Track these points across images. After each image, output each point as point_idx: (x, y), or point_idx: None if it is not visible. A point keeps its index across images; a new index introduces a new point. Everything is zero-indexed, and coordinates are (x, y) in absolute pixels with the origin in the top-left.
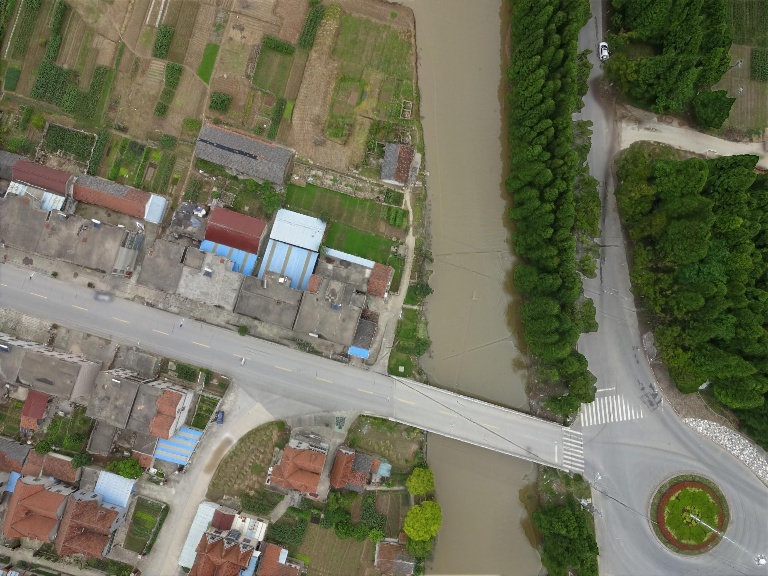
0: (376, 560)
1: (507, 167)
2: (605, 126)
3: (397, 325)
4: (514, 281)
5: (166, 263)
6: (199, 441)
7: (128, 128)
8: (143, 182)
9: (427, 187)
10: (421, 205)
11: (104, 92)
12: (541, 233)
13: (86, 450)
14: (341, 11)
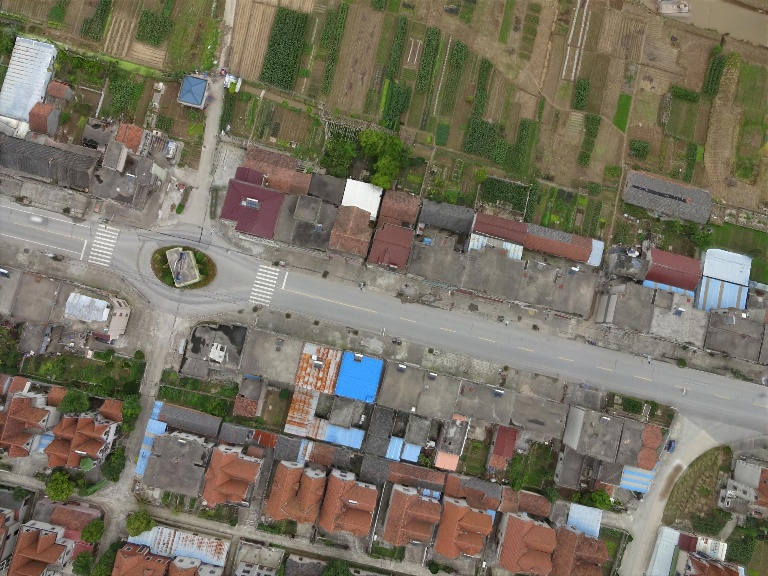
0: None
1: None
2: None
3: None
4: None
5: (638, 305)
6: None
7: (554, 177)
8: (573, 227)
9: None
10: None
11: (529, 144)
12: None
13: (551, 485)
14: (740, 60)
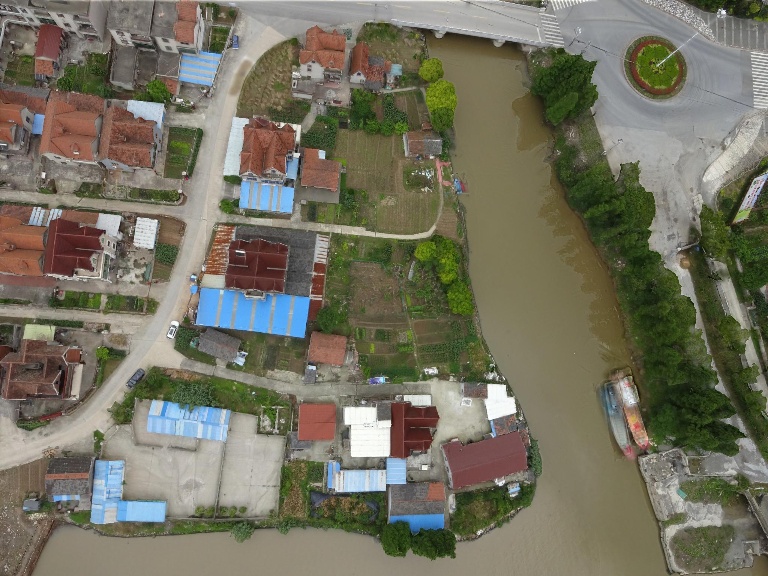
0: (406, 151)
1: None
2: None
3: None
4: None
5: None
6: (220, 64)
7: None
8: None
9: None
10: None
11: None
12: None
13: None
14: None
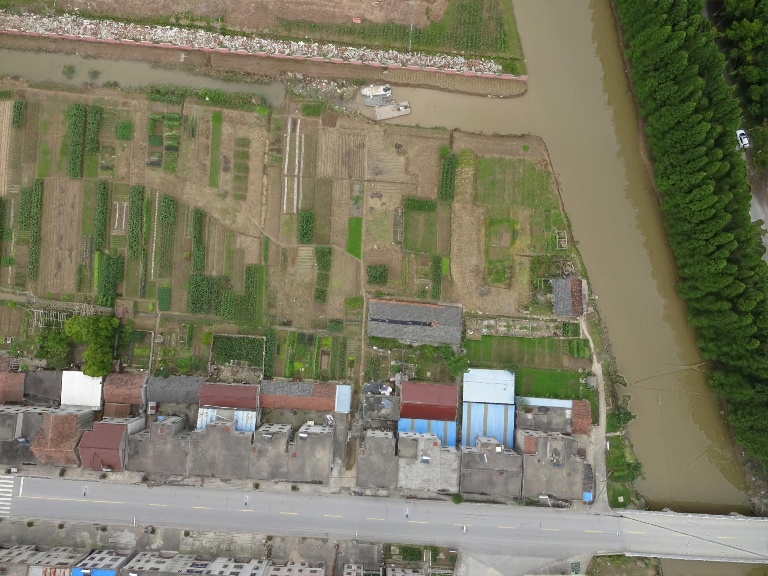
0: None
1: (672, 272)
2: (761, 212)
3: (606, 456)
4: (712, 387)
5: (380, 459)
6: None
7: (292, 321)
8: (320, 372)
9: (598, 310)
10: (598, 330)
11: (259, 290)
12: (745, 345)
13: None
14: (474, 156)
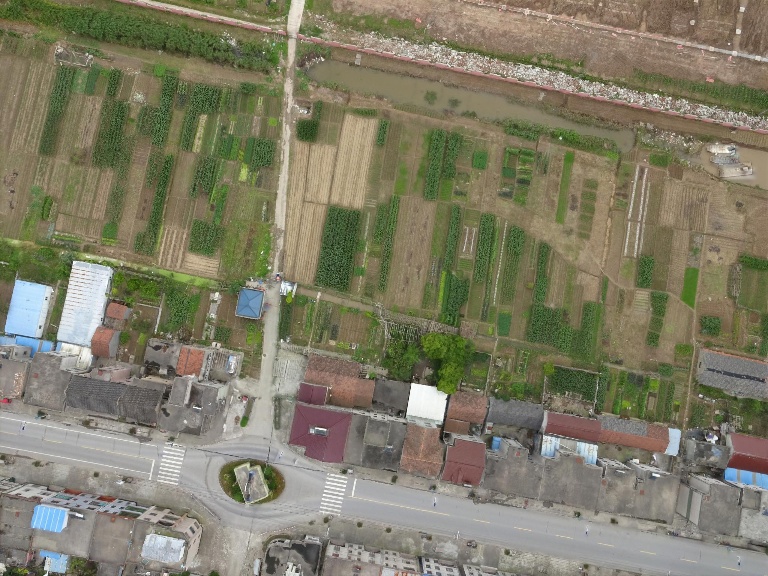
0: None
1: None
2: None
3: None
4: None
5: (724, 507)
6: None
7: (623, 360)
8: (646, 412)
9: None
10: None
11: (595, 327)
12: None
13: None
14: None
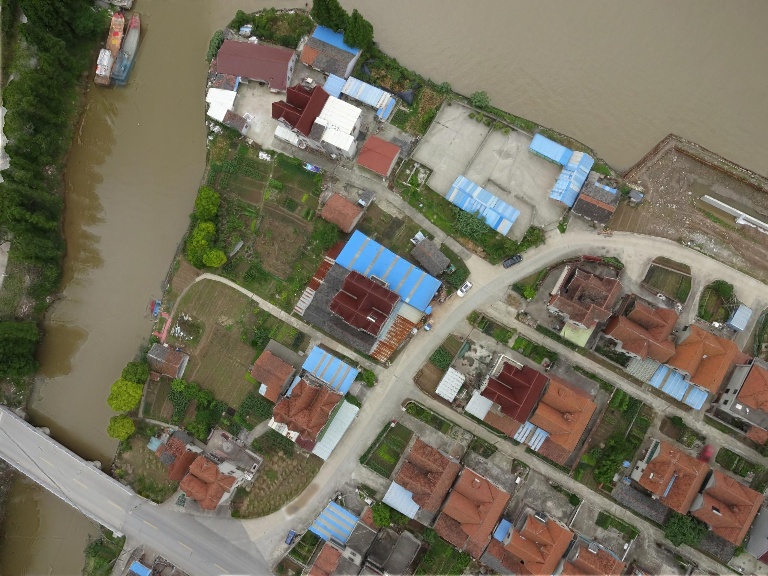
0: (186, 361)
1: None
2: None
3: None
4: None
5: None
6: None
7: None
8: None
9: None
10: None
11: None
12: None
13: None
14: None
